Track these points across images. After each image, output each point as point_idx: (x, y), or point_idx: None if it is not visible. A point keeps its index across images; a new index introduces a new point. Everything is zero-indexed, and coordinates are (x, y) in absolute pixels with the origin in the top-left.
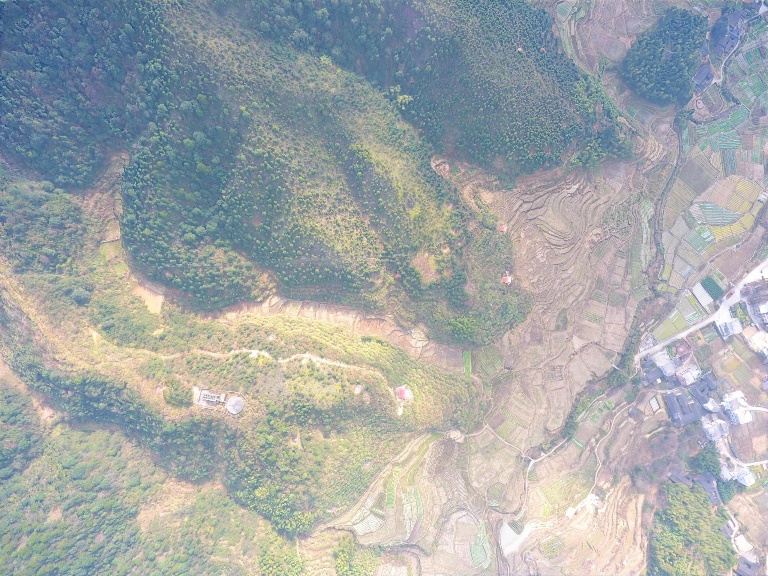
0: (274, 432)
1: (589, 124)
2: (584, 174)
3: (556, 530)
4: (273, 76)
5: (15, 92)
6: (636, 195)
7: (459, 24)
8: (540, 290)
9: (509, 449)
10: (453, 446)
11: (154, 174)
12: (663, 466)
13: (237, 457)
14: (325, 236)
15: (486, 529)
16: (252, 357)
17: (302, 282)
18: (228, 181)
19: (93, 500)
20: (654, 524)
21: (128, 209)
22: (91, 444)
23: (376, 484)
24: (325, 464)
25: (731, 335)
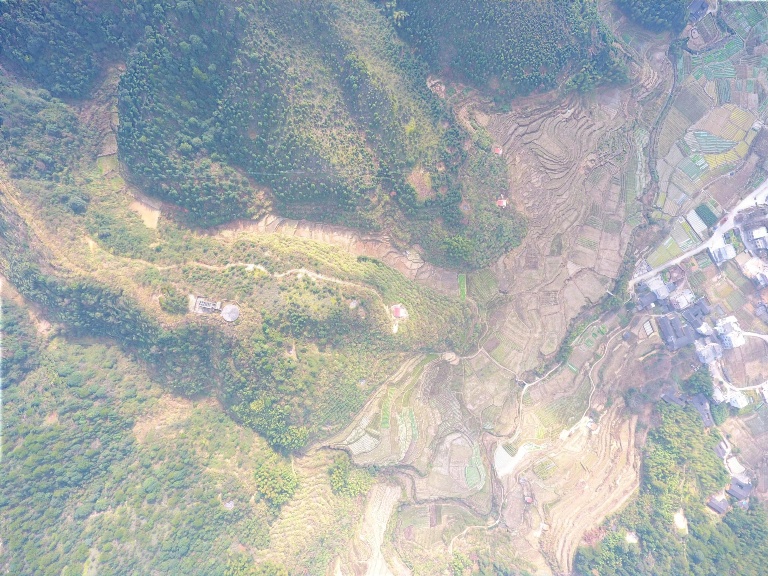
0: (269, 342)
1: (584, 46)
2: (579, 99)
3: (550, 452)
4: None
5: None
6: (631, 122)
7: None
8: (535, 215)
9: (504, 372)
10: (448, 368)
11: (150, 77)
12: (656, 386)
13: (232, 367)
14: (321, 148)
15: (480, 451)
16: (248, 270)
17: (298, 198)
18: (224, 90)
19: (89, 407)
20: (647, 443)
21: (124, 117)
22: (87, 356)
23: (371, 404)
24: (320, 376)
25: (725, 261)
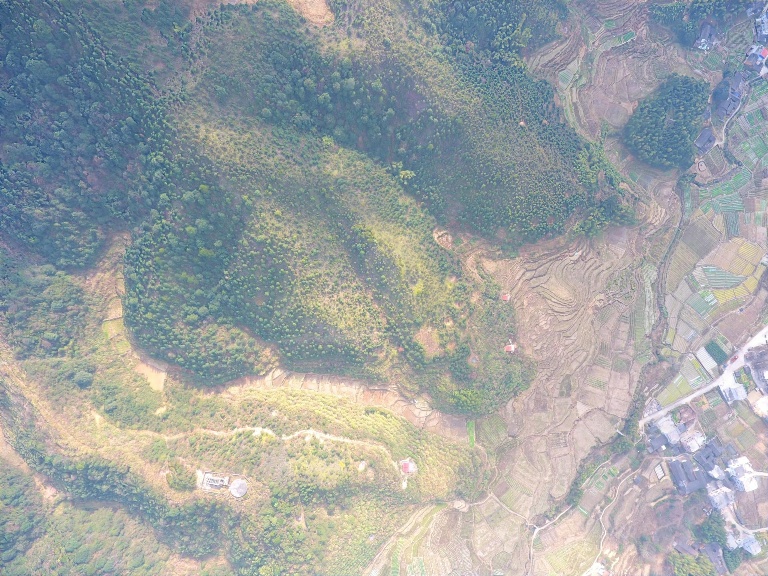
0: (278, 513)
1: (592, 193)
2: (587, 241)
3: None
4: (275, 164)
5: (17, 184)
6: (639, 260)
7: (461, 105)
8: (544, 357)
9: (514, 517)
10: (457, 515)
11: (156, 261)
12: (669, 536)
13: (241, 538)
14: (328, 315)
15: None
16: (255, 435)
17: (305, 357)
18: (230, 263)
19: None
20: None
21: (130, 292)
22: (94, 524)
23: (380, 556)
24: (329, 543)
25: (735, 400)
